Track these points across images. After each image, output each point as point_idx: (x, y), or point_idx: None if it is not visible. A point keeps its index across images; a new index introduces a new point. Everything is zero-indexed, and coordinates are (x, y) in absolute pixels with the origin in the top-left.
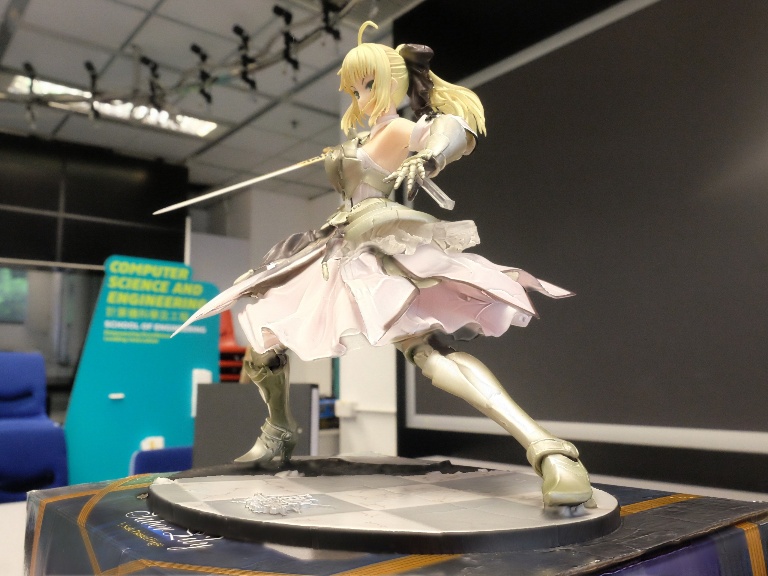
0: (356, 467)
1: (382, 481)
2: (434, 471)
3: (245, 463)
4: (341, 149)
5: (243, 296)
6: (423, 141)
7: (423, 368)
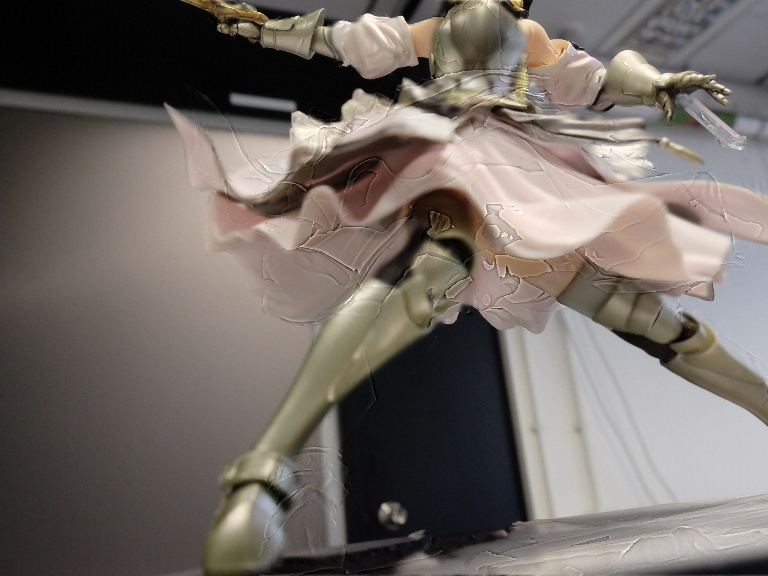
0: (389, 573)
1: (596, 536)
2: (521, 539)
3: (343, 573)
4: (506, 1)
5: (466, 107)
6: (573, 68)
7: (716, 322)
